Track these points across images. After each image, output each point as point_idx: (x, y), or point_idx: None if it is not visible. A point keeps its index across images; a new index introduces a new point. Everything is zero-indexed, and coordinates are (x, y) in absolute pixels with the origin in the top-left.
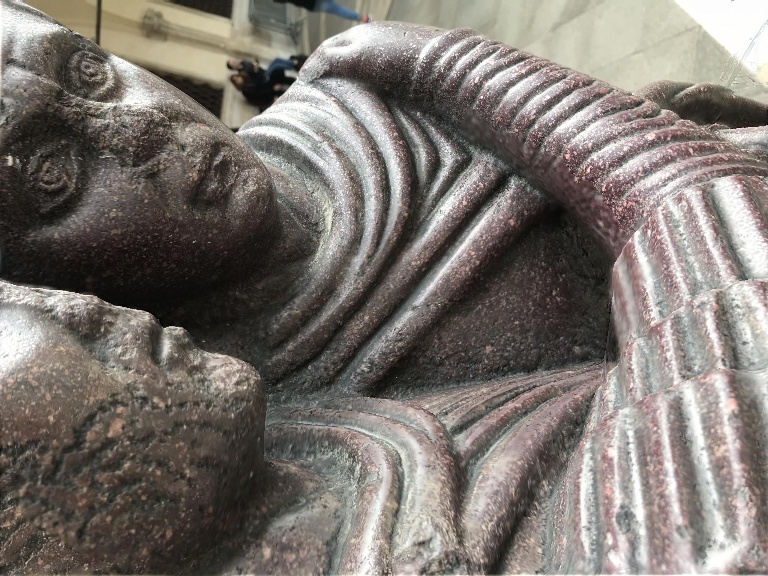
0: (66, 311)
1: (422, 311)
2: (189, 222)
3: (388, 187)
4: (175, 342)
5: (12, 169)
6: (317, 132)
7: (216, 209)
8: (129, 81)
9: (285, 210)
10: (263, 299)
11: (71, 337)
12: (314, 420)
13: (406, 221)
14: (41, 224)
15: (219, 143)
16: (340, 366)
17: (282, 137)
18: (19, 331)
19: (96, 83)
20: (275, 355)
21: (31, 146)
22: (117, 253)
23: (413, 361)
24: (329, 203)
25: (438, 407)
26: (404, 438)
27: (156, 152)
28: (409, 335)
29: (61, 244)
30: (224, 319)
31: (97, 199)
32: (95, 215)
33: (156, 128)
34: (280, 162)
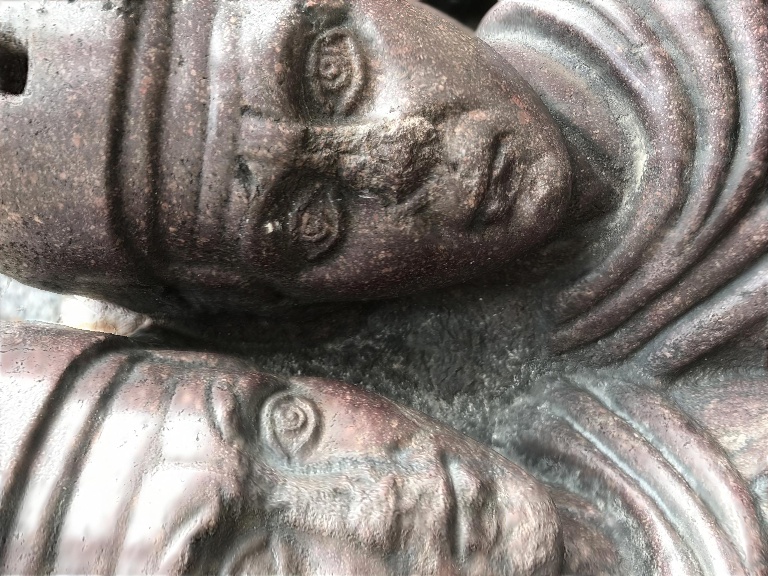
0: (368, 542)
1: (756, 299)
2: (465, 248)
3: (735, 127)
4: (471, 522)
5: (274, 233)
6: (632, 25)
7: (497, 226)
8: (378, 61)
9: (579, 155)
10: (548, 264)
11: (376, 567)
12: (605, 442)
13: (756, 182)
14: (311, 265)
15: (498, 135)
16: (636, 344)
17: (578, 28)
18: (331, 571)
19: (341, 88)
20: (560, 330)
21: (287, 201)
22: (390, 284)
23: (731, 345)
24: (641, 142)
25: (759, 459)
26: (715, 561)
27: (423, 180)
28: (732, 325)
29: (334, 283)
30: (502, 281)
31: (363, 241)
32: (363, 257)
33: (420, 150)
34: (573, 61)
